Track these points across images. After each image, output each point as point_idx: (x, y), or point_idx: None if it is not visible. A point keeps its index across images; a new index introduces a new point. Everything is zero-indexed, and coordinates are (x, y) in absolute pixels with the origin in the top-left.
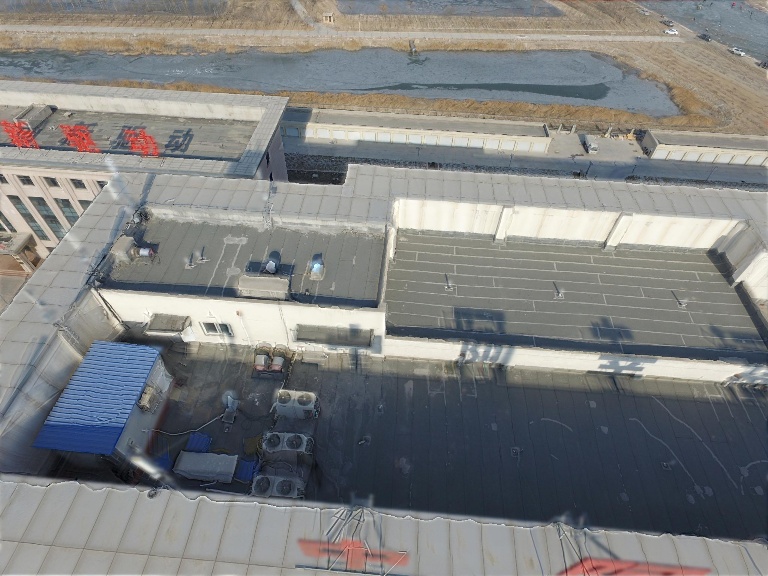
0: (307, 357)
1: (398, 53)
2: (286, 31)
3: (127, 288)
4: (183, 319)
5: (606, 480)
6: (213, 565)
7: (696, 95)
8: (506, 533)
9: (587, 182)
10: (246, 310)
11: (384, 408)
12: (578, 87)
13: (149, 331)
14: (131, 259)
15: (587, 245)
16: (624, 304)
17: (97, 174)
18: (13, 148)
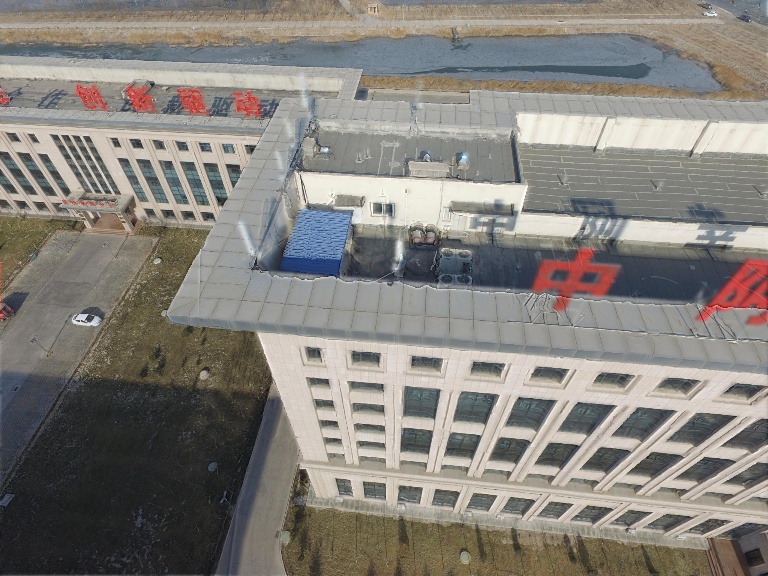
0: (451, 235)
1: (441, 40)
2: (333, 22)
3: None
4: (359, 199)
5: None
6: (449, 319)
7: (738, 72)
8: (656, 308)
9: (676, 100)
10: (414, 188)
11: (521, 268)
12: (619, 67)
13: (336, 206)
14: (313, 155)
15: (675, 154)
16: (713, 194)
17: (200, 136)
18: (130, 113)
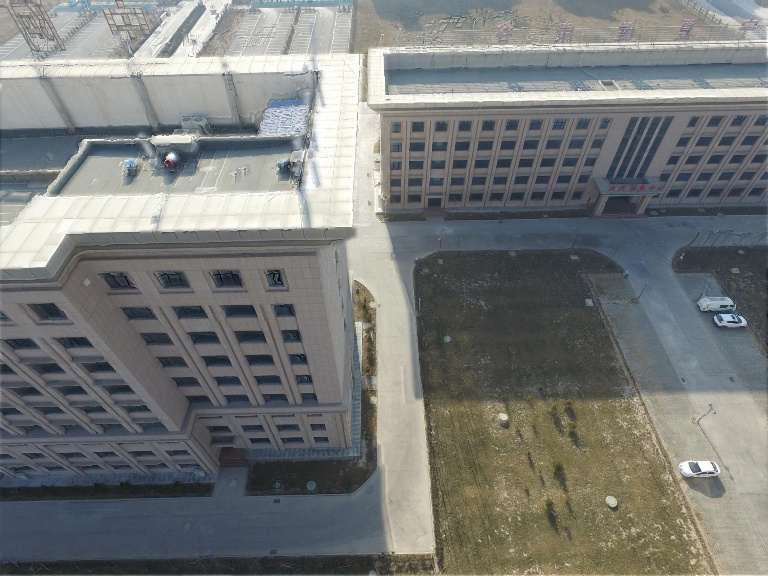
0: None
1: None
2: None
3: (288, 147)
4: None
5: (4, 156)
6: None
7: None
8: None
9: None
10: None
11: None
12: None
13: None
14: None
15: None
16: None
17: None
18: None
